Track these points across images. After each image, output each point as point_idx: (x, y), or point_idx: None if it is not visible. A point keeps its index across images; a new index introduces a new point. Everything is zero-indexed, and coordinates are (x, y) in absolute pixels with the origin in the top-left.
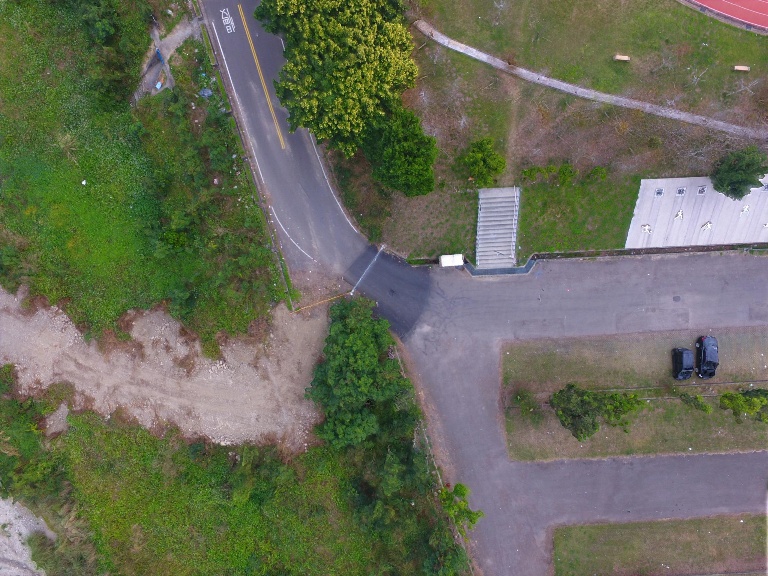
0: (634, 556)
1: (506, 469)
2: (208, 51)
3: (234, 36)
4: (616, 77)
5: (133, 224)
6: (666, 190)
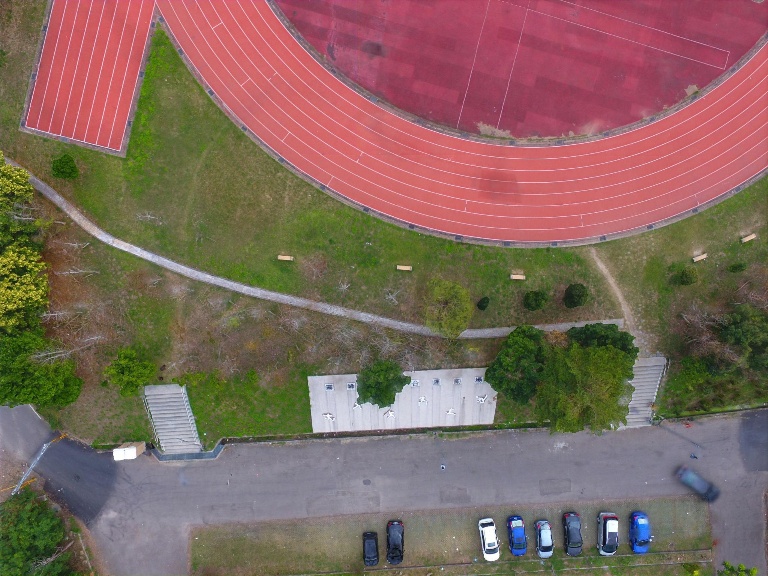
0: None
1: None
2: None
3: None
4: (281, 275)
5: None
6: (336, 385)
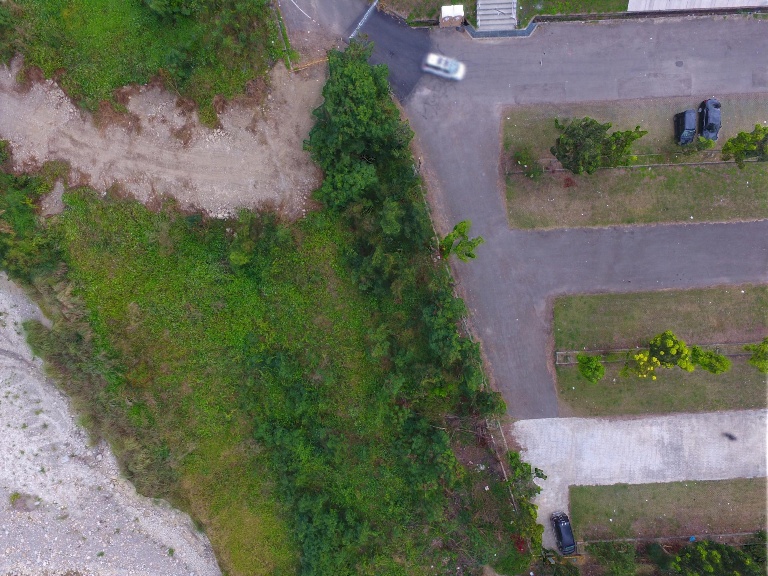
0: (634, 327)
1: (506, 237)
2: None
3: None
4: None
5: None
6: None
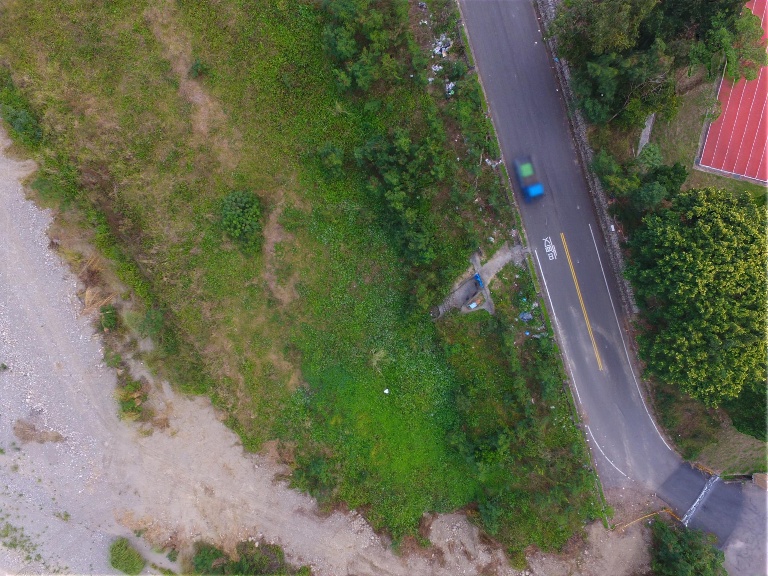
0: None
1: None
2: (534, 280)
3: (556, 263)
4: None
5: (434, 432)
6: None
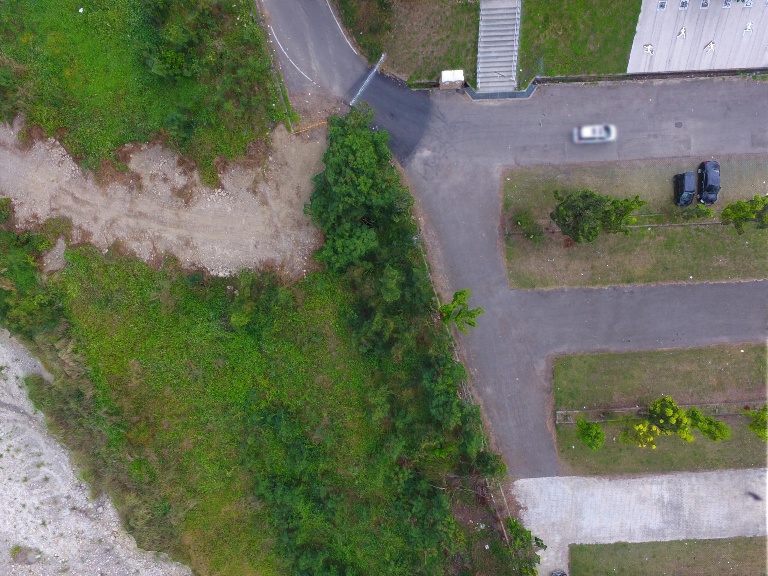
0: (634, 386)
1: (506, 297)
2: None
3: None
4: None
5: (131, 53)
6: (669, 3)
